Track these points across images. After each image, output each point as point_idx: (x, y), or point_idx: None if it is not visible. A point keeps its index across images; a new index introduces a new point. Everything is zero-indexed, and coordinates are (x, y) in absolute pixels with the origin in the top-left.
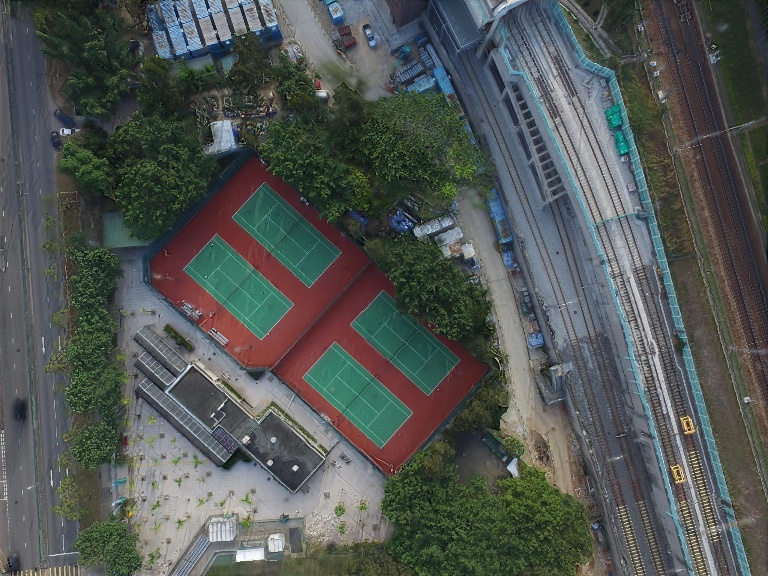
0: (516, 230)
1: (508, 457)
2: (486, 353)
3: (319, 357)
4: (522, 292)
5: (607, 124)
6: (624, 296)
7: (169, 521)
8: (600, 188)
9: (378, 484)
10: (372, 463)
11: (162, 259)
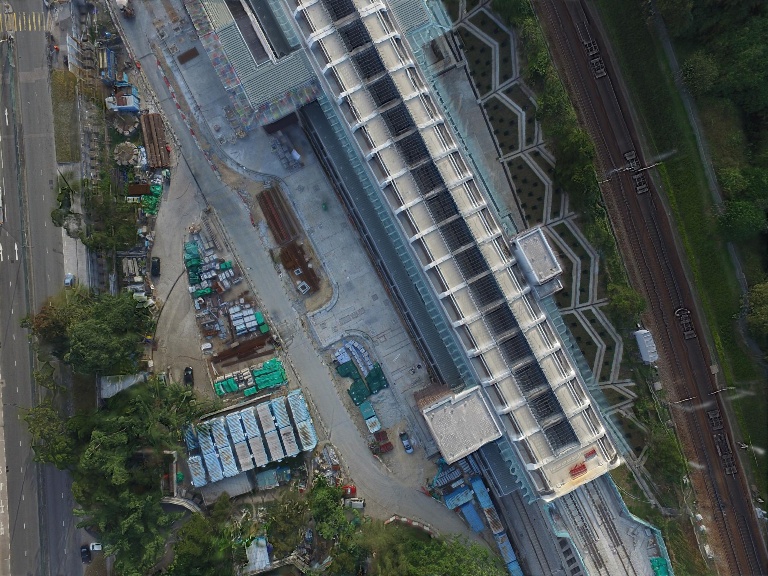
0: None
1: None
2: None
3: None
4: None
5: (653, 572)
6: None
7: None
8: None
9: None
10: None
11: None
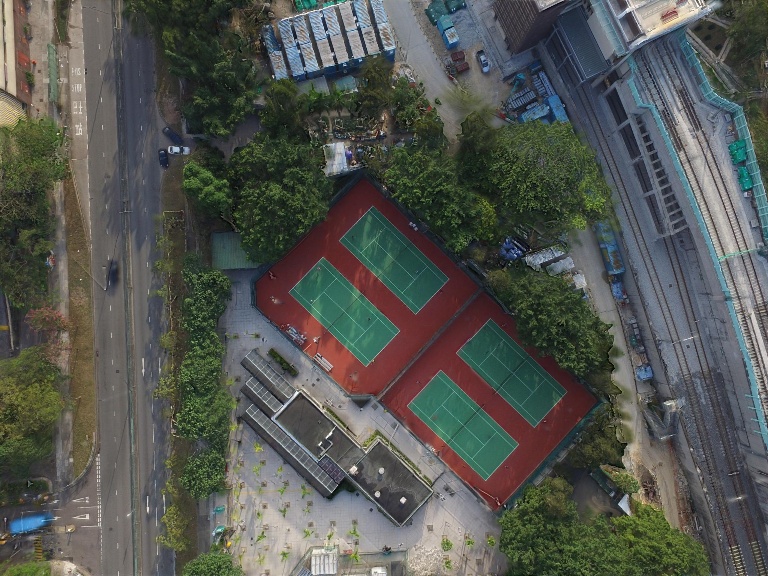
0: (631, 262)
1: (616, 492)
2: (612, 389)
3: (424, 385)
4: (631, 324)
5: (730, 159)
6: (745, 333)
7: (268, 552)
8: (723, 223)
9: (482, 517)
10: (477, 495)
11: (268, 282)
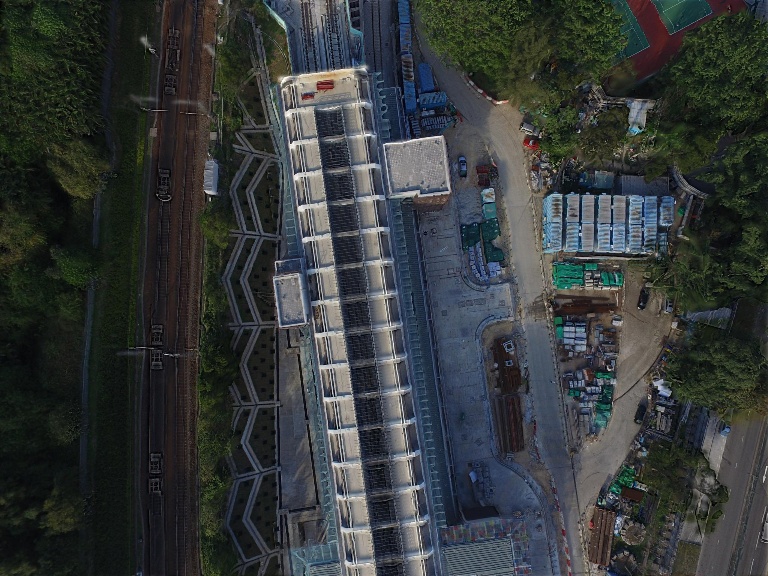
0: None
1: None
2: None
3: None
4: None
5: None
6: None
7: None
8: None
9: None
10: None
11: None
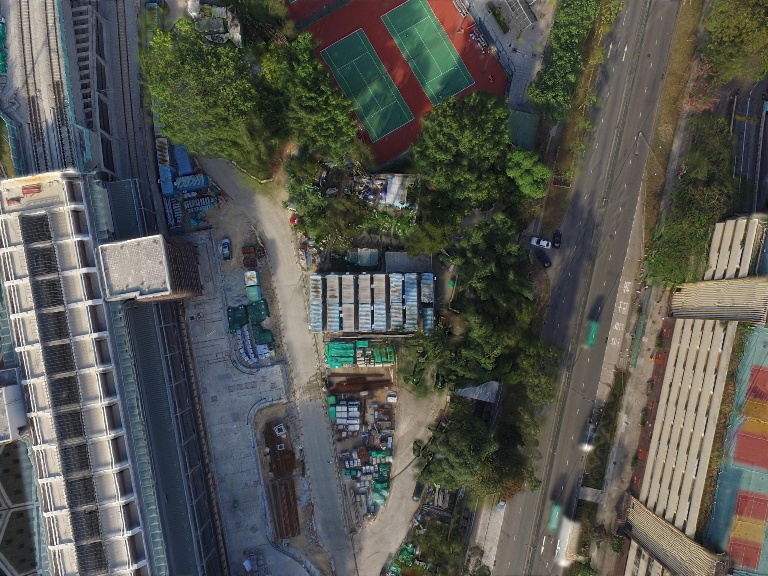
0: (138, 4)
1: None
2: None
3: None
4: None
5: (8, 61)
6: None
7: None
8: None
9: None
10: None
11: None
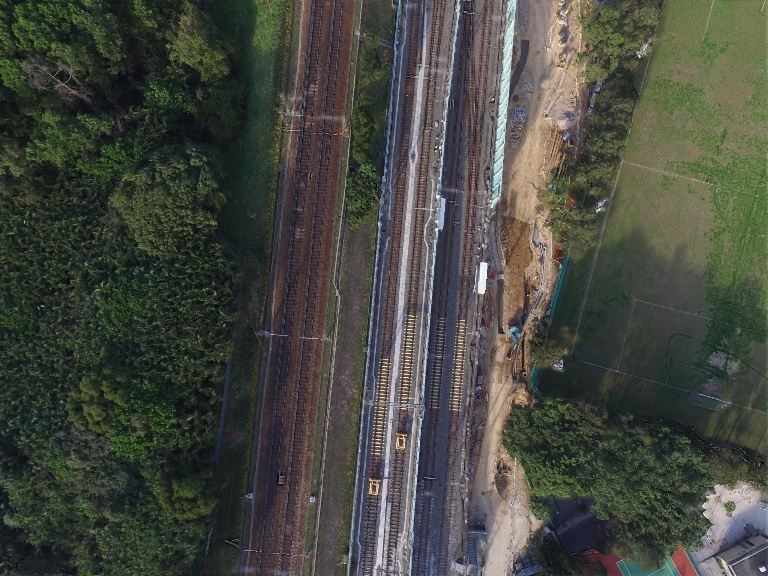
0: None
1: None
2: None
3: None
4: None
5: None
6: None
7: None
8: None
9: None
10: None
11: None
